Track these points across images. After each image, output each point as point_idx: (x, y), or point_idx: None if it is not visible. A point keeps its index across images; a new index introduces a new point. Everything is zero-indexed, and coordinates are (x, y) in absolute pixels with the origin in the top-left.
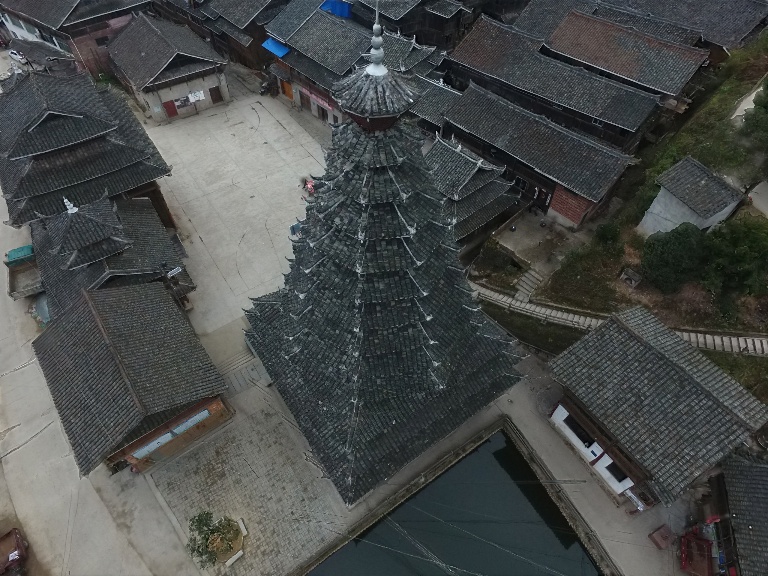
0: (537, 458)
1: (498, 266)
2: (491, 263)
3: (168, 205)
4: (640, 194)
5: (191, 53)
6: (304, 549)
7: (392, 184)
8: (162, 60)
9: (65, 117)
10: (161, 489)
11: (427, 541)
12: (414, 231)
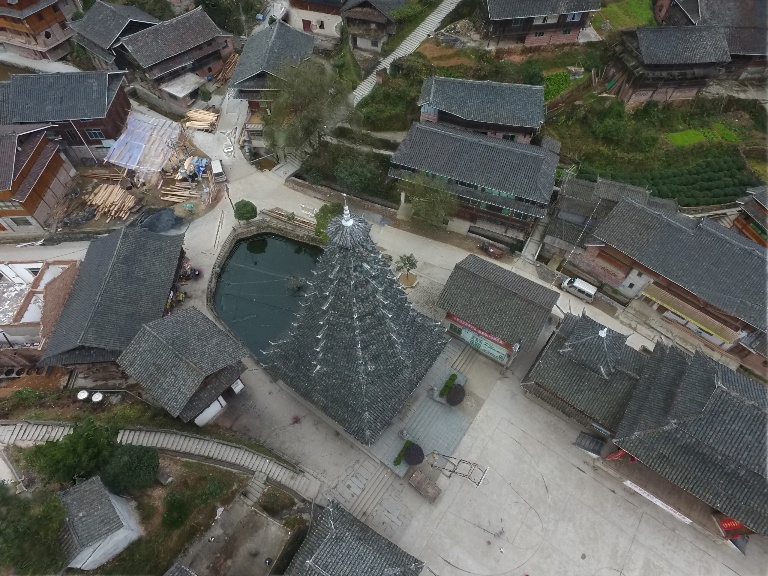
0: None
1: None
2: None
3: (654, 506)
4: None
5: None
6: None
7: None
8: None
9: None
10: None
11: None
12: None
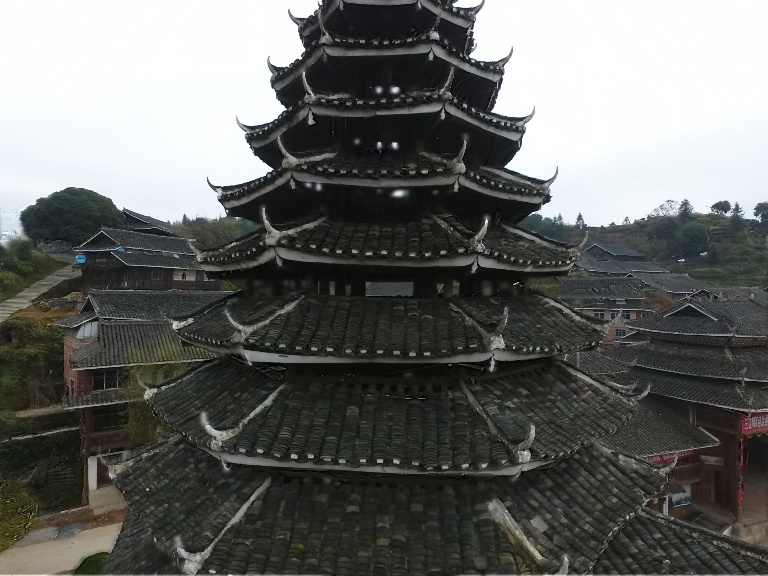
0: None
1: None
2: None
3: None
4: None
5: None
6: None
7: None
8: None
9: None
10: None
11: None
12: (272, 77)
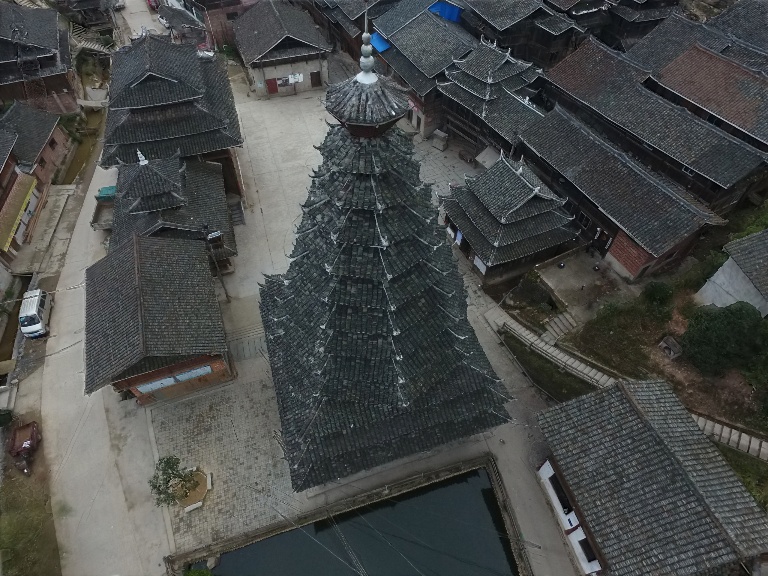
0: (509, 508)
1: (535, 300)
2: (529, 296)
3: (243, 174)
4: (710, 259)
5: (299, 37)
6: (256, 520)
7: (371, 192)
8: (273, 40)
9: (163, 79)
10: (155, 425)
11: (381, 553)
12: (386, 243)
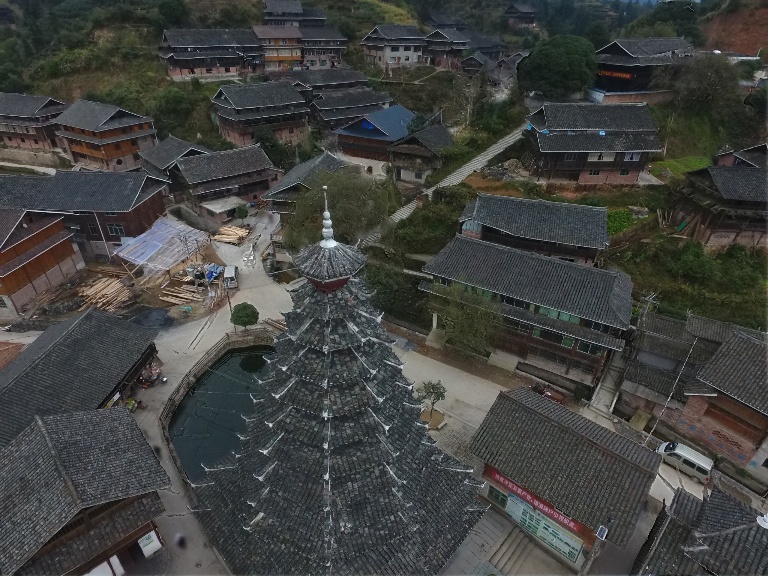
0: None
1: None
2: None
3: None
4: None
5: None
6: None
7: None
8: None
9: None
10: None
11: None
12: None
